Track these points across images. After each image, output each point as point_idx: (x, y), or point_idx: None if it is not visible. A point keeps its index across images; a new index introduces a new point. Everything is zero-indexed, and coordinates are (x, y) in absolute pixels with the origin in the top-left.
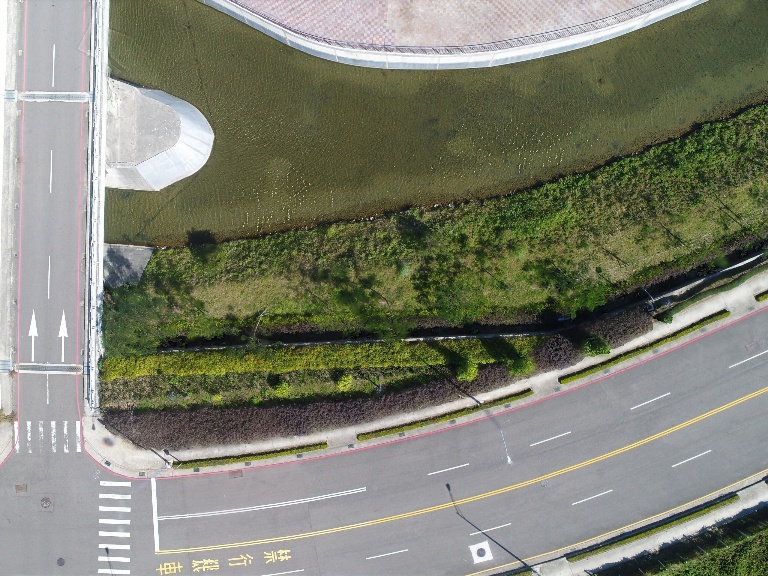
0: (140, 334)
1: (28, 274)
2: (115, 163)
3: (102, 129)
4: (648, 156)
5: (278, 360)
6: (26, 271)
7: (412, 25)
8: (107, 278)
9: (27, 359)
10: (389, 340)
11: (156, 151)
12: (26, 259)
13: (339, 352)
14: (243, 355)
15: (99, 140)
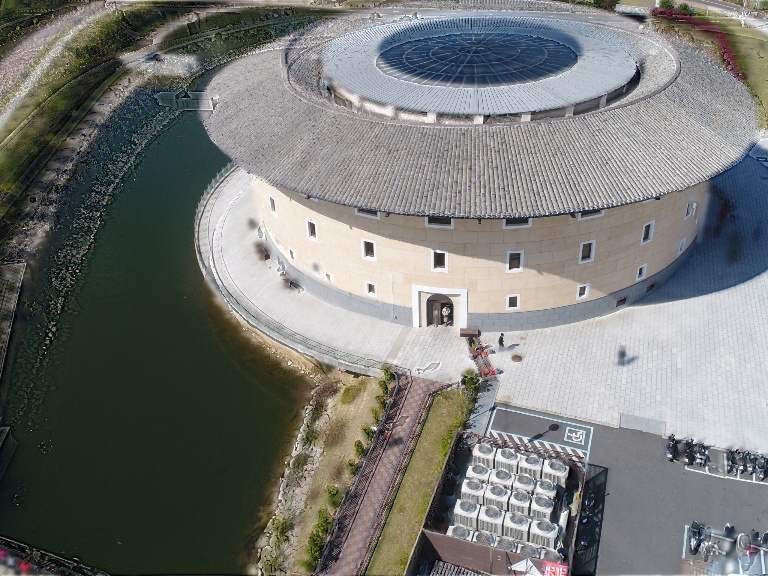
0: (90, 3)
1: (142, 3)
2: (165, 21)
3: (170, 8)
4: (1, 107)
5: (47, 21)
6: (143, 3)
7: (136, 55)
8: (129, 21)
9: (116, 3)
10: (21, 38)
11: (159, 25)
12: (147, 3)
13: (32, 28)
14: (59, 18)
15: (166, 7)
